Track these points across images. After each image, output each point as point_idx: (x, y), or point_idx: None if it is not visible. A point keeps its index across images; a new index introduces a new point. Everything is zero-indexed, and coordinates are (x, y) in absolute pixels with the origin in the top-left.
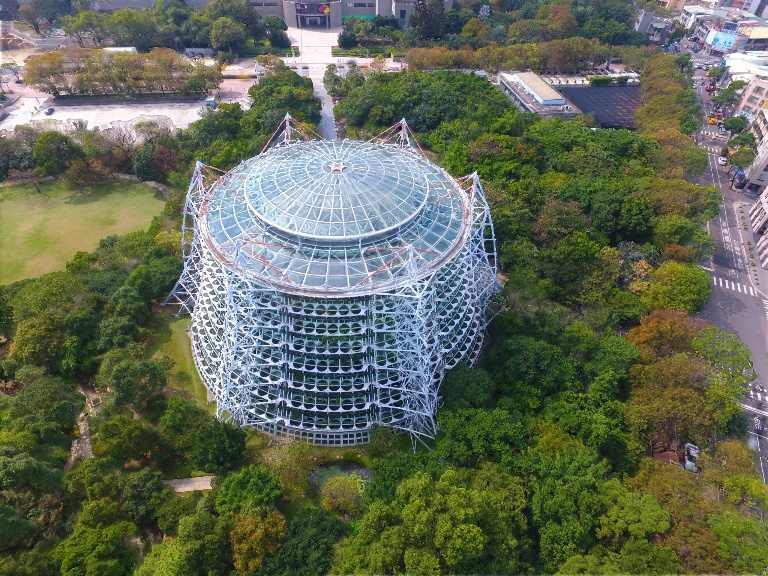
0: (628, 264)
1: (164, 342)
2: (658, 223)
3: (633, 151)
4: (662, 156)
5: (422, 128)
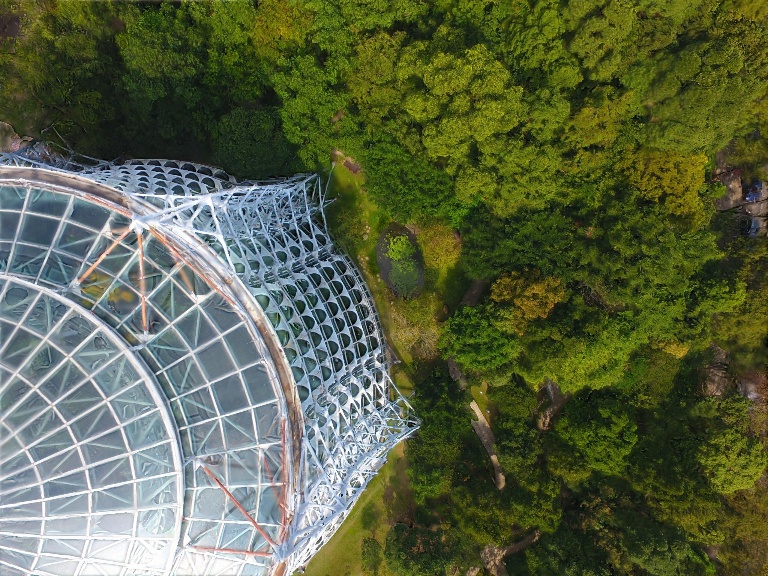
0: None
1: None
2: None
3: None
4: None
5: None
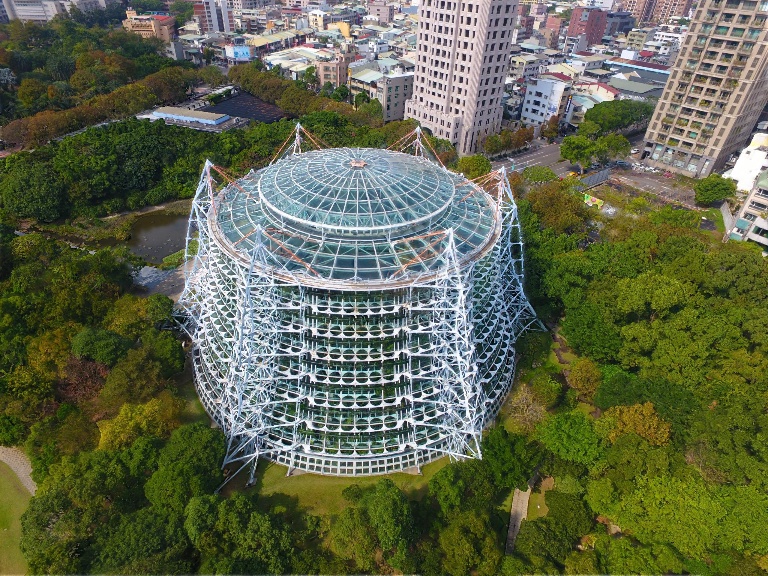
0: None
1: (295, 504)
2: None
3: (341, 121)
4: (358, 117)
5: (149, 183)
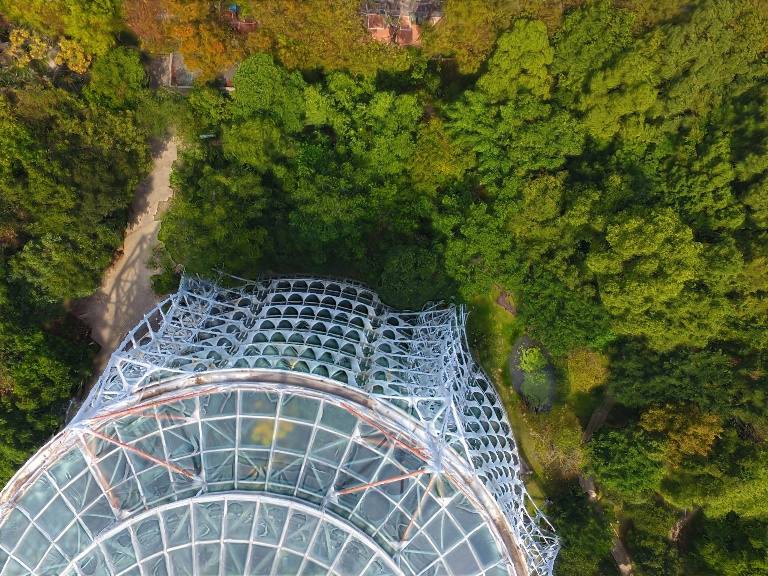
0: (7, 75)
1: None
2: None
3: None
4: None
5: None
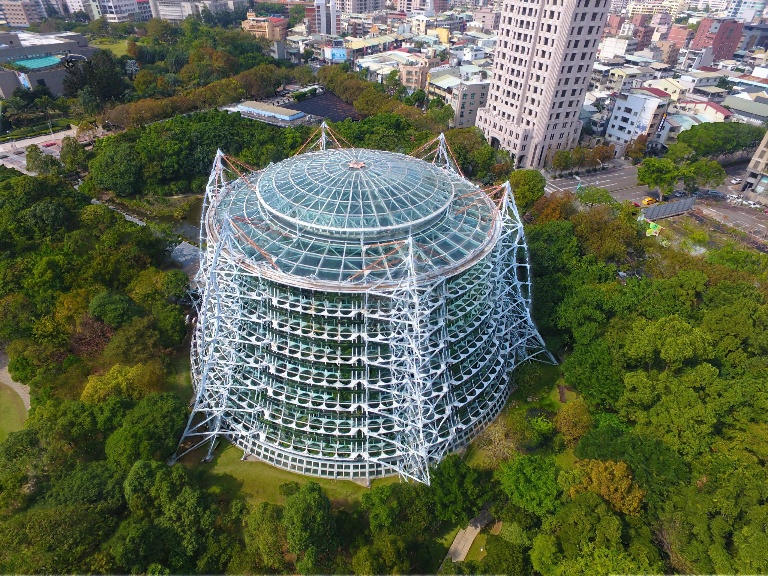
0: None
1: (238, 488)
2: (474, 157)
3: (404, 124)
4: (422, 122)
5: None
